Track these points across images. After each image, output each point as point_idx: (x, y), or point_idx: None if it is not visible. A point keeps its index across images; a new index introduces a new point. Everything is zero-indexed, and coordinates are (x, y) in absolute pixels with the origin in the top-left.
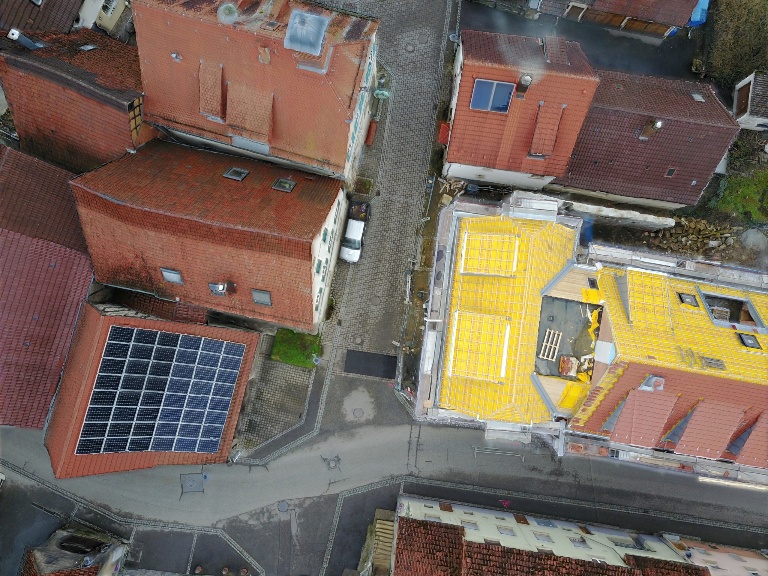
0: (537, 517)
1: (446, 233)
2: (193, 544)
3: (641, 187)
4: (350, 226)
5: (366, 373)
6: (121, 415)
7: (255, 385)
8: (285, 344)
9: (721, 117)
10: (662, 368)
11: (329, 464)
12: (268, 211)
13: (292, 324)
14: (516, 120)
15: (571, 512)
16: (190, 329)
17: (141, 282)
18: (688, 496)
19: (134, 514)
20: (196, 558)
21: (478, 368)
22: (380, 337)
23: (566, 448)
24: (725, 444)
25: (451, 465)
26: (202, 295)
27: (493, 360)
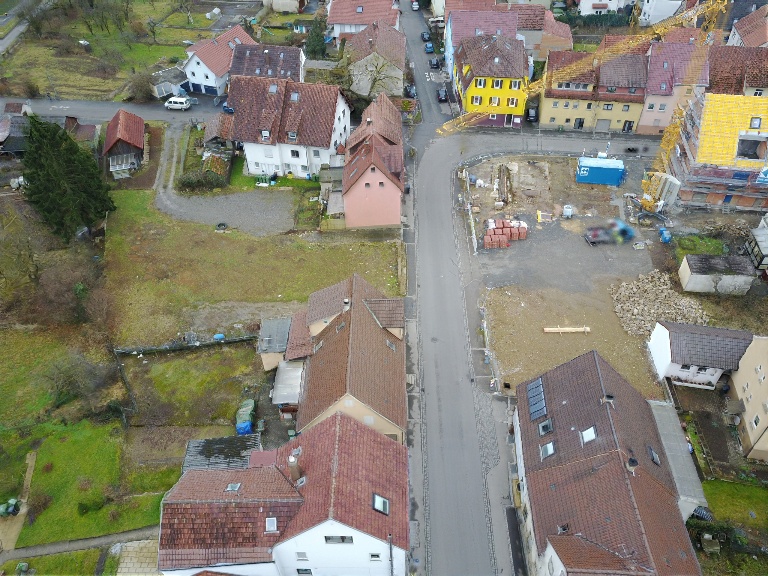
0: None
1: None
2: None
3: None
4: None
5: None
6: None
7: None
8: None
9: None
10: None
11: None
12: None
13: None
14: None
15: None
16: None
17: None
18: None
19: None
20: None
21: None
22: None
23: None
24: None
25: None
26: None
27: None
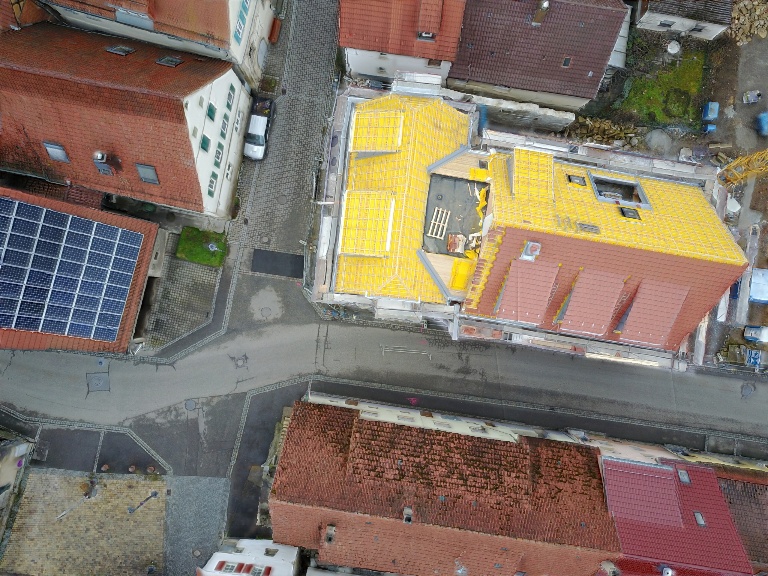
0: (444, 414)
1: (341, 119)
2: (100, 443)
3: (540, 79)
4: (253, 121)
5: (273, 272)
6: (5, 291)
7: (162, 284)
8: (190, 242)
9: (612, 2)
10: (538, 233)
11: (237, 363)
12: (145, 77)
13: (183, 206)
14: None
15: (478, 409)
16: (81, 212)
17: (30, 164)
18: (593, 393)
19: (40, 413)
20: (103, 456)
21: (365, 244)
22: (287, 236)
23: (460, 331)
24: (608, 318)
25: (359, 364)
26: (91, 176)
27: (379, 235)
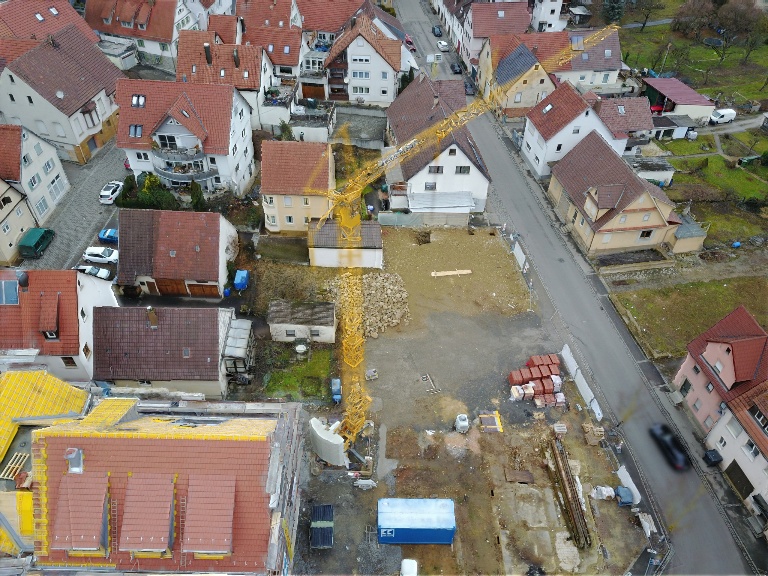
0: None
1: None
2: None
3: (170, 370)
4: None
5: None
6: None
7: None
8: None
9: None
10: (75, 438)
11: None
12: None
13: None
14: (28, 310)
15: None
16: None
17: None
18: None
19: None
20: None
21: None
22: None
23: None
24: (166, 527)
25: None
26: None
27: None
